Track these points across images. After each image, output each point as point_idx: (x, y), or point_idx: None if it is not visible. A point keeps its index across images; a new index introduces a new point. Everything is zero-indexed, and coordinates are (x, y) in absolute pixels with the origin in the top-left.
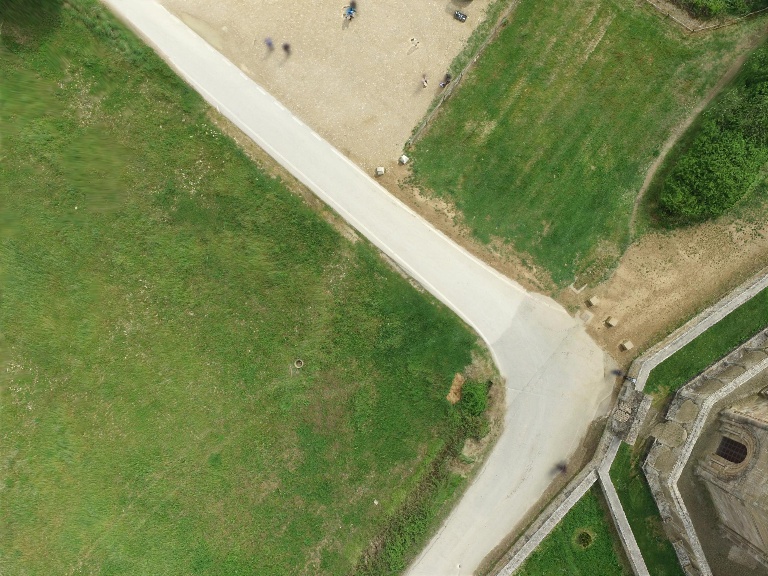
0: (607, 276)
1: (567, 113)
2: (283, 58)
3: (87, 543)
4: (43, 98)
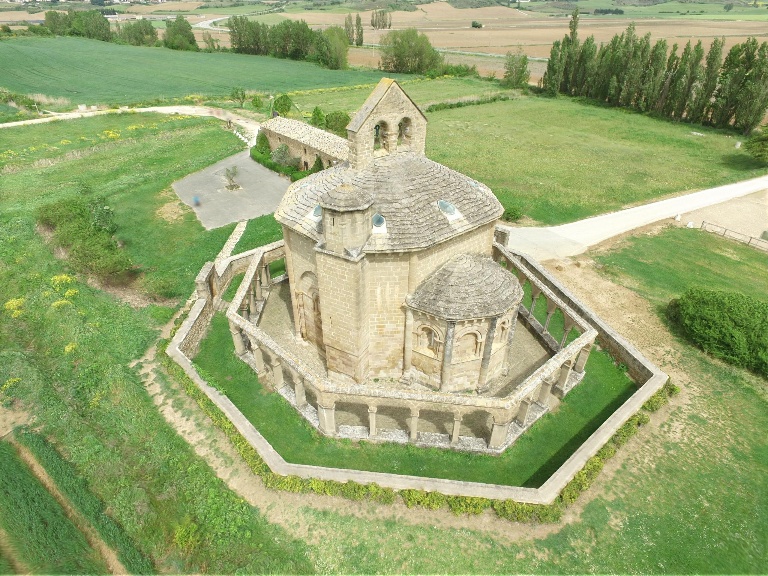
0: (604, 277)
1: (767, 291)
2: (752, 208)
3: (464, 144)
4: (692, 163)
